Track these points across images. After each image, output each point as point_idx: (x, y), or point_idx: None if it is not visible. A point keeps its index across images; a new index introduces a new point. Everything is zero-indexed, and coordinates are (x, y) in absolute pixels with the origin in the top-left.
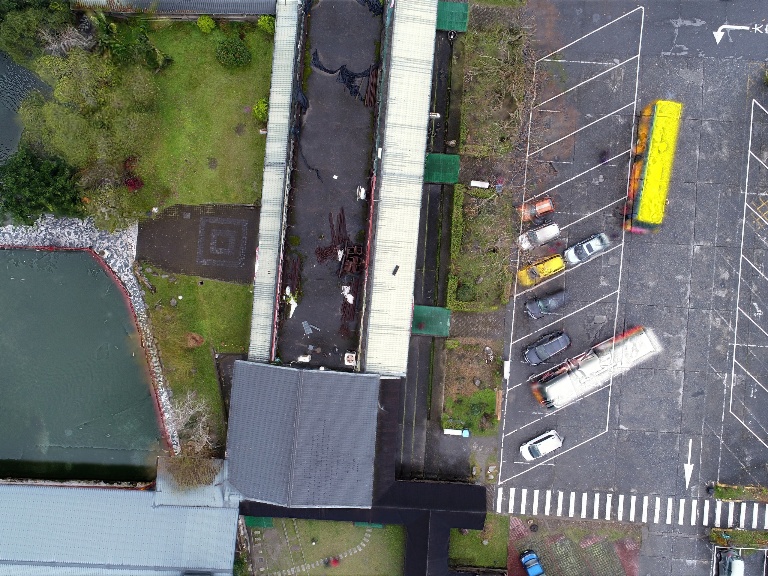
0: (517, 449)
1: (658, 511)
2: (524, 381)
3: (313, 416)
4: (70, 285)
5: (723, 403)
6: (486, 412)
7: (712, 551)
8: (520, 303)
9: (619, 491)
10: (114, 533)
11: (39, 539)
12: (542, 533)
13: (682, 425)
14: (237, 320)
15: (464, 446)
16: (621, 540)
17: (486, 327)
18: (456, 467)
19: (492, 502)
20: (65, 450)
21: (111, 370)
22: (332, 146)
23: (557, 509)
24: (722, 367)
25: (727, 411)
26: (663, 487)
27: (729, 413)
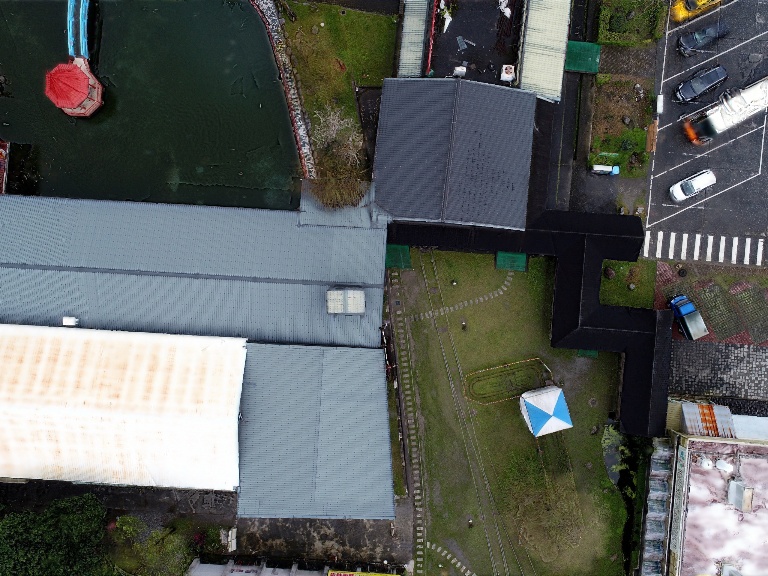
0: (666, 191)
1: None
2: (675, 121)
3: (469, 128)
4: (205, 16)
5: None
6: (635, 152)
7: None
8: (672, 40)
9: None
10: (259, 249)
11: (181, 253)
12: (690, 278)
13: None
14: (379, 52)
15: (611, 187)
16: None
17: (636, 64)
18: (602, 209)
19: None
20: (196, 188)
21: (238, 119)
22: None
23: (706, 254)
24: None
25: None
26: None
27: None
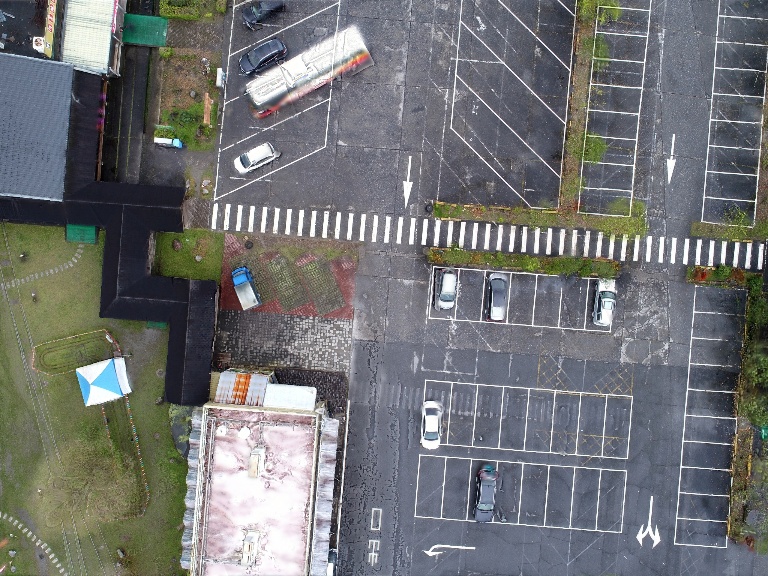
0: (233, 164)
1: (376, 229)
2: (241, 94)
3: None
4: None
5: (444, 119)
6: (201, 125)
7: (430, 271)
8: (239, 14)
9: (337, 209)
10: None
11: None
12: (257, 251)
13: (402, 141)
14: None
15: (179, 160)
16: (338, 259)
17: (204, 38)
18: (171, 182)
19: (207, 218)
20: None
21: None
22: None
23: (273, 226)
24: (443, 82)
25: (448, 127)
26: (381, 205)
27: (450, 130)
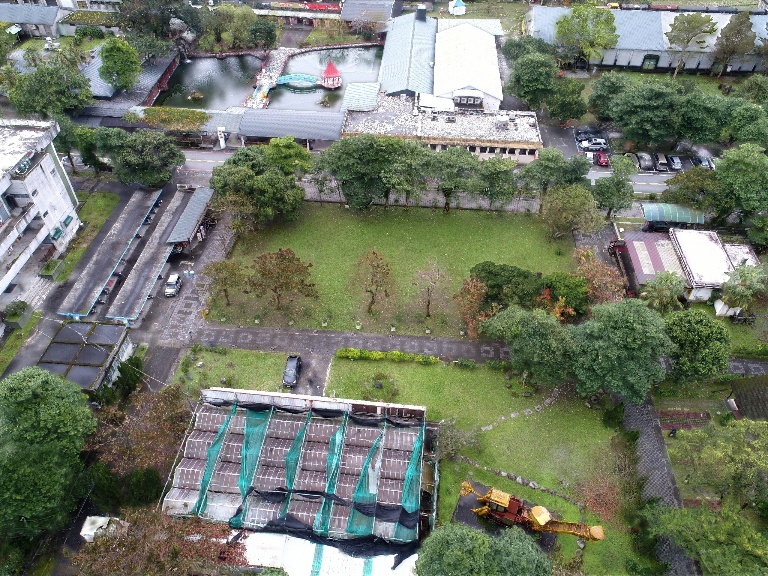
0: None
1: None
2: None
3: (361, 2)
4: None
5: None
6: None
7: None
8: None
9: None
10: None
11: None
12: None
13: None
14: None
15: None
16: None
17: None
18: None
19: None
20: None
21: None
22: (266, 2)
23: None
24: None
25: None
26: None
27: None
